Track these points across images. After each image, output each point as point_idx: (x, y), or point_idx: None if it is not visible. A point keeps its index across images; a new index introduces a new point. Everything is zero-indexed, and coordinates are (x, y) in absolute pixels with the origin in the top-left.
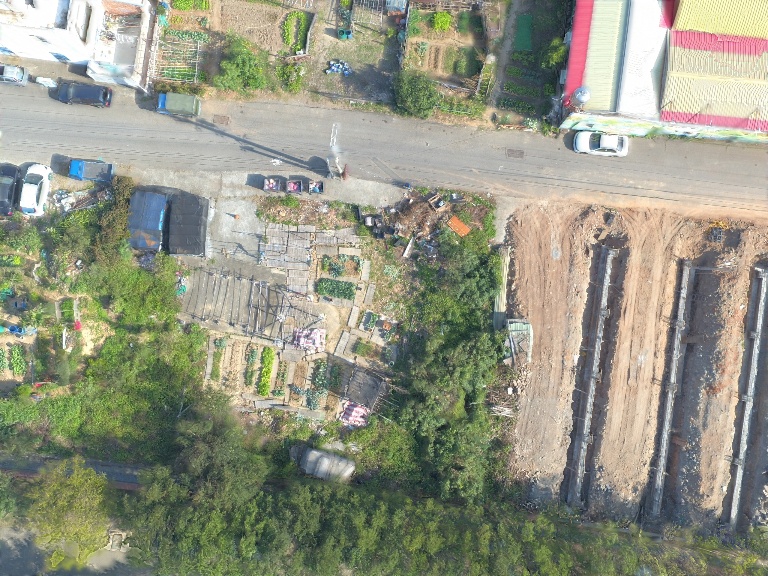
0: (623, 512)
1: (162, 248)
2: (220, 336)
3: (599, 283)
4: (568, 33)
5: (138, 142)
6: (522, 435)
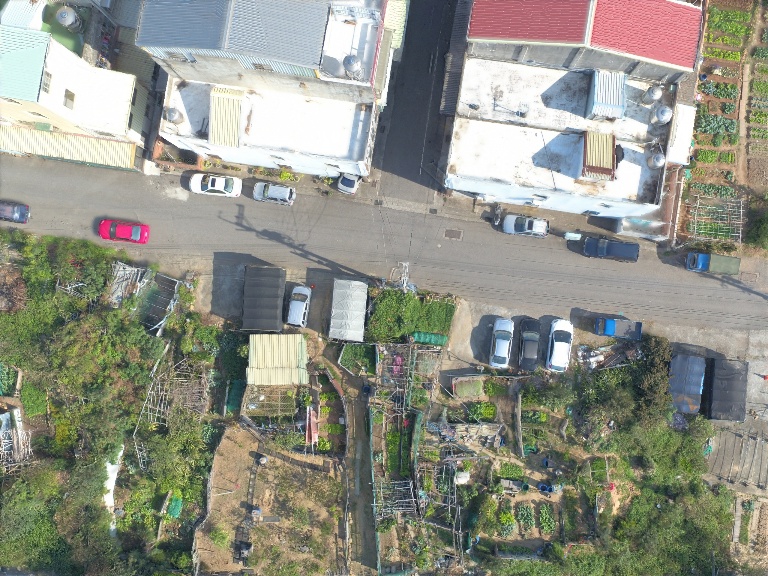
0: None
1: None
2: (747, 498)
3: None
4: None
5: (661, 298)
6: None
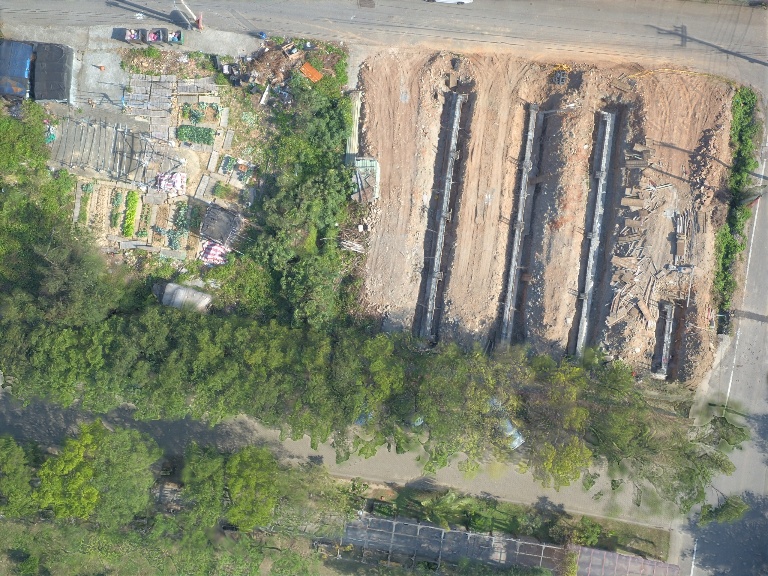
0: (471, 344)
1: (30, 96)
2: (87, 182)
3: (450, 128)
4: None
5: (11, 0)
6: (372, 270)
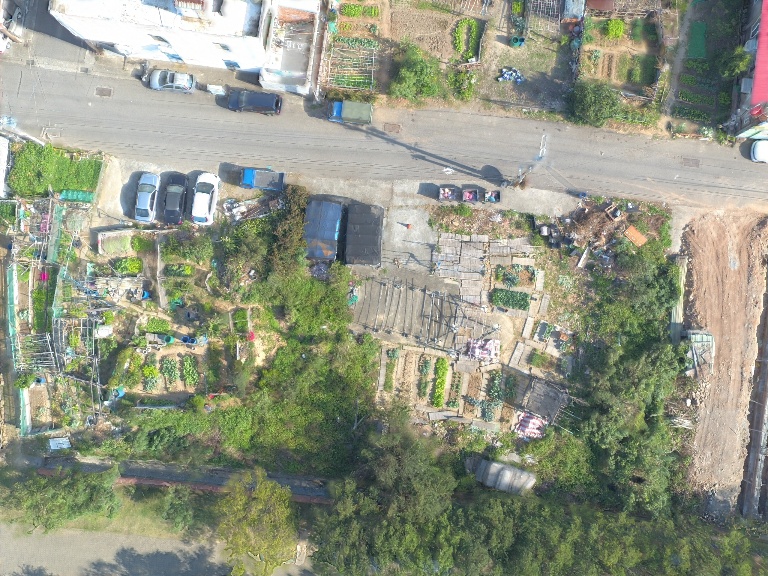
0: None
1: (336, 258)
2: (392, 347)
3: None
4: (750, 41)
5: (307, 150)
6: (701, 447)
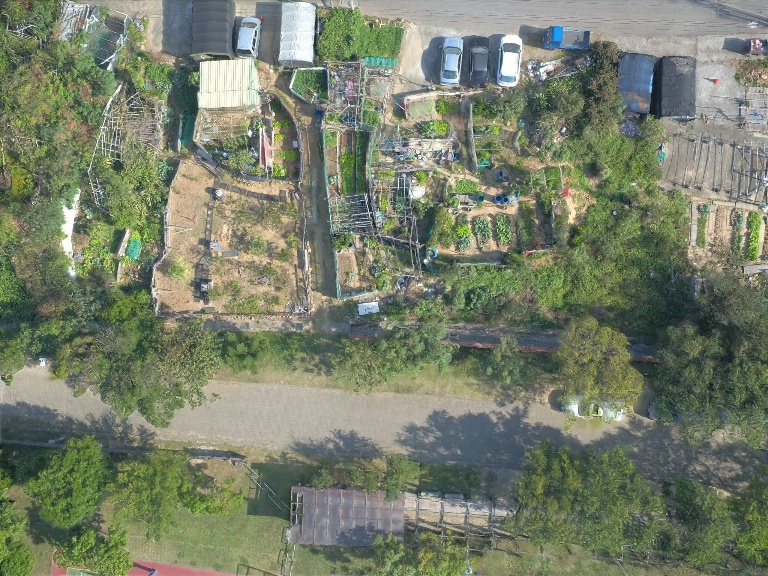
0: None
1: None
2: (702, 202)
3: None
4: None
5: (608, 10)
6: None
